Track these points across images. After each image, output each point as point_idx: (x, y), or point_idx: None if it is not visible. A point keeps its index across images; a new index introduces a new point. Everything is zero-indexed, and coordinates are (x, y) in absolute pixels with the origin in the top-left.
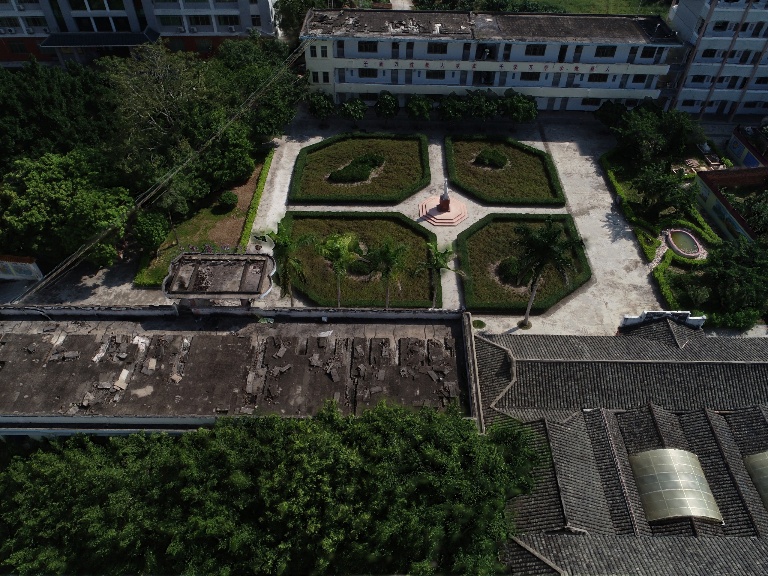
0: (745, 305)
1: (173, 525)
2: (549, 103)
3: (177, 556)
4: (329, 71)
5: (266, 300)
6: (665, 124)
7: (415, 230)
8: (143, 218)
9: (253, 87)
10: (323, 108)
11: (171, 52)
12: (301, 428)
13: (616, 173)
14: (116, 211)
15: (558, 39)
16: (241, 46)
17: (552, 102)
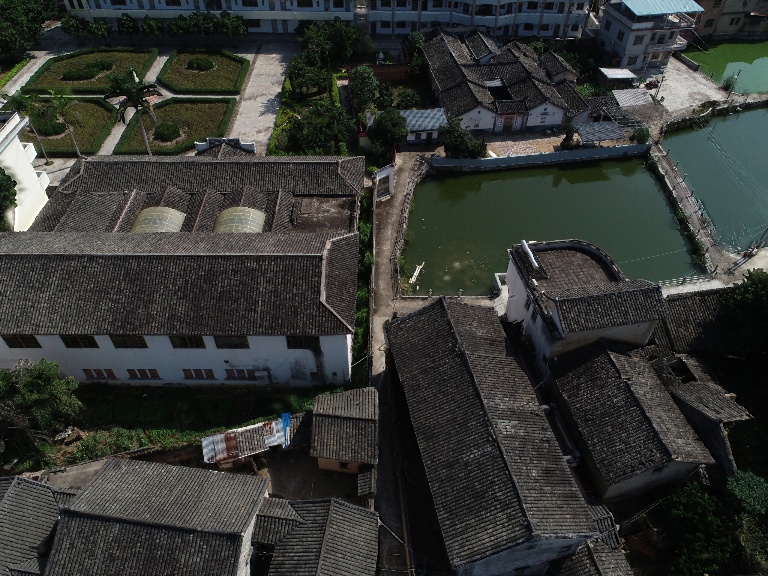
0: (314, 145)
1: None
2: (274, 27)
3: None
4: None
5: None
6: None
7: (106, 108)
8: None
9: None
10: (72, 27)
11: None
12: None
13: None
14: None
15: None
16: None
17: (276, 26)
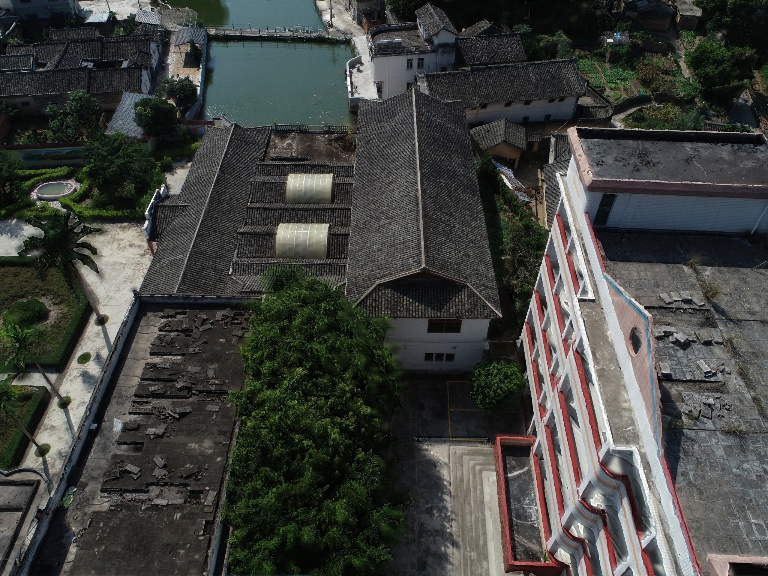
0: None
1: (336, 567)
2: None
3: (363, 566)
4: None
5: None
6: None
7: None
8: None
9: None
10: None
11: None
12: None
13: None
14: None
15: None
16: None
17: None
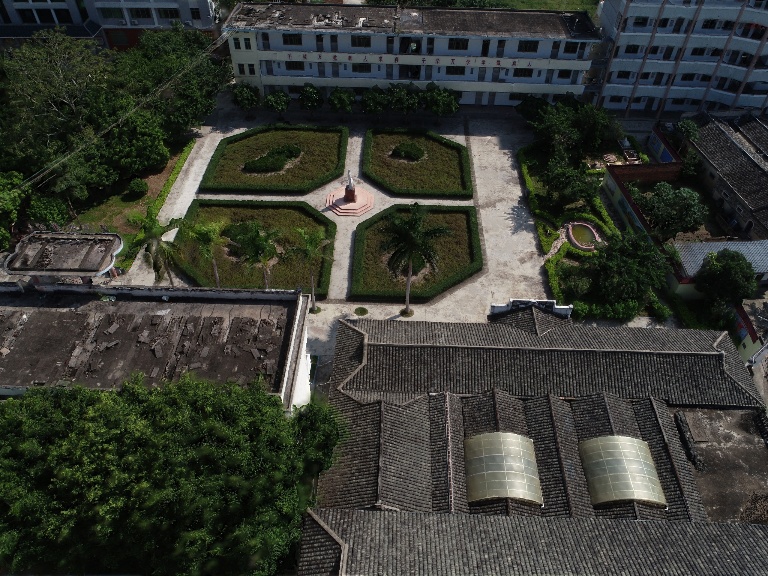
0: (625, 296)
1: None
2: (477, 98)
3: None
4: (254, 63)
5: (123, 280)
6: (579, 118)
7: (317, 219)
8: (36, 202)
9: (167, 77)
10: (246, 99)
11: (69, 40)
12: (102, 399)
13: (530, 167)
14: (8, 194)
15: (479, 33)
16: (160, 37)
17: (480, 97)
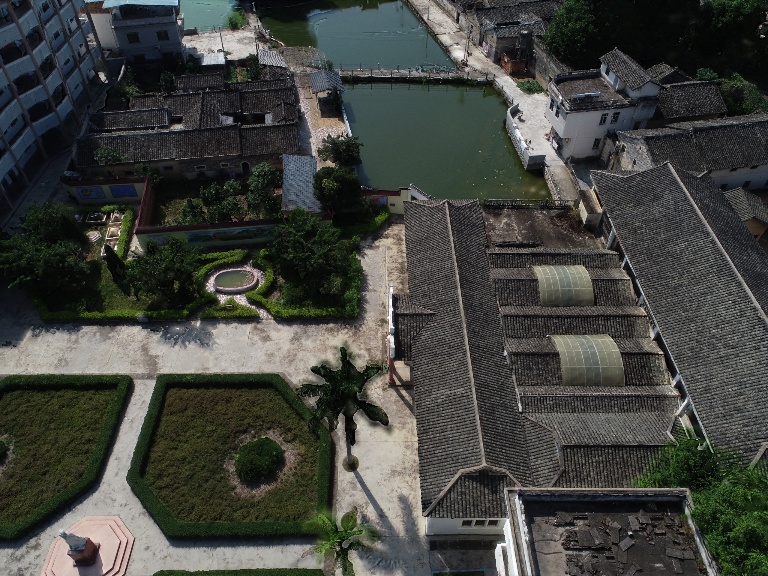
0: None
1: None
2: None
3: None
4: None
5: None
6: (48, 230)
7: None
8: None
9: None
10: None
11: None
12: None
13: (87, 309)
14: None
15: None
16: None
17: None
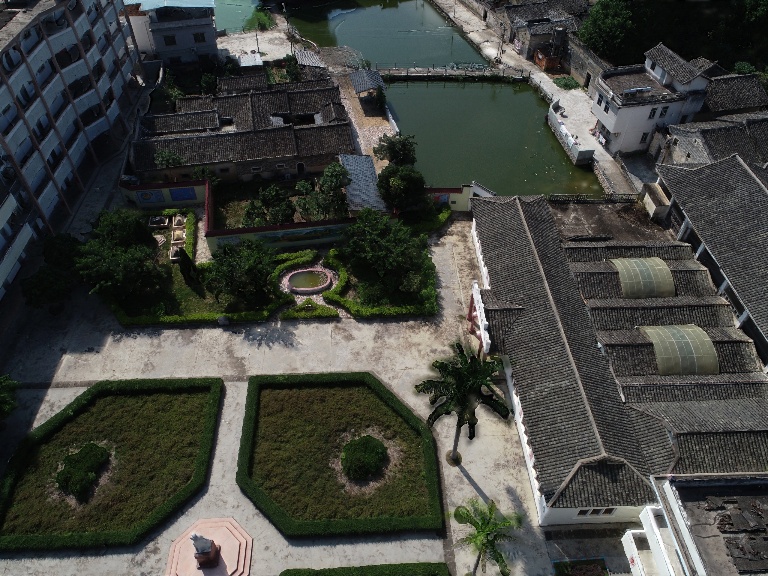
0: None
1: None
2: None
3: None
4: None
5: None
6: (123, 235)
7: None
8: None
9: None
10: None
11: None
12: None
13: (166, 313)
14: None
15: None
16: None
17: None
